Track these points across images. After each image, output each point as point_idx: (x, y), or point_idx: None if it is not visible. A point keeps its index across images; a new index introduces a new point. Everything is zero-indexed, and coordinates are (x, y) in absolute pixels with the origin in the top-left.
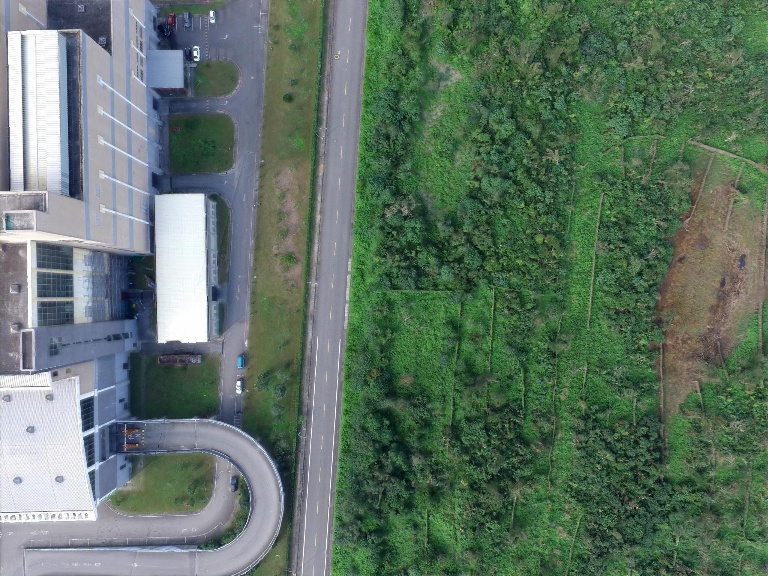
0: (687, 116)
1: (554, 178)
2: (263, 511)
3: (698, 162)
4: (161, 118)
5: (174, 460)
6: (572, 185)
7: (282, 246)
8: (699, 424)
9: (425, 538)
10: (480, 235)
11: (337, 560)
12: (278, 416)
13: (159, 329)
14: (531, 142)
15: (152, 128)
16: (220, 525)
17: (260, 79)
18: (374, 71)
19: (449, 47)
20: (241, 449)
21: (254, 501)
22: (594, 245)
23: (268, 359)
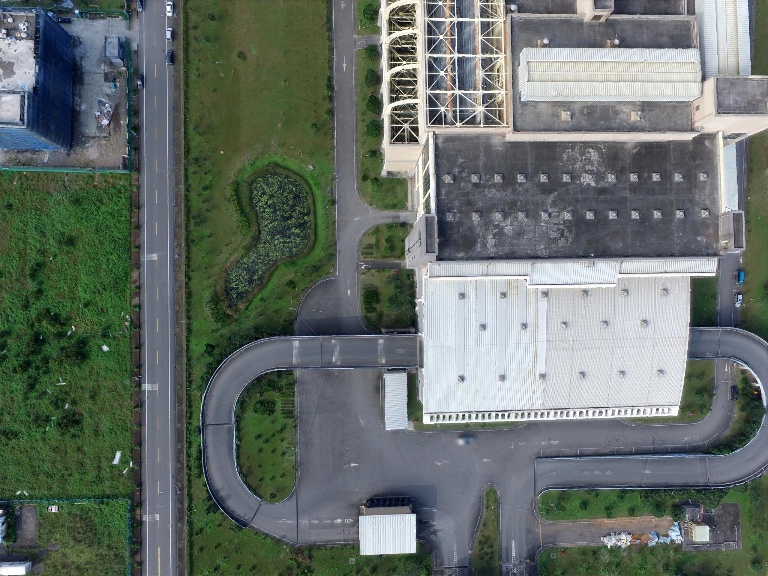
0: None
1: None
2: None
3: None
4: None
5: None
6: None
7: None
8: None
9: None
10: None
11: None
12: None
13: None
14: None
15: None
16: (720, 433)
17: (750, 13)
18: None
19: None
20: (758, 356)
21: (766, 407)
22: None
23: (764, 275)
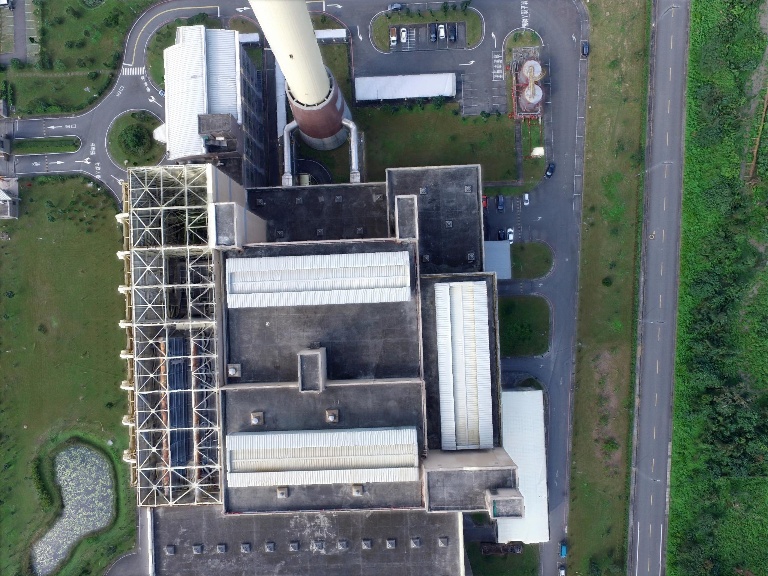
0: None
1: None
2: None
3: None
4: None
5: None
6: None
7: (602, 431)
8: None
9: None
10: None
11: None
12: None
13: (500, 529)
14: None
15: None
16: None
17: (575, 261)
18: (692, 252)
19: None
20: None
21: None
22: None
23: (590, 546)
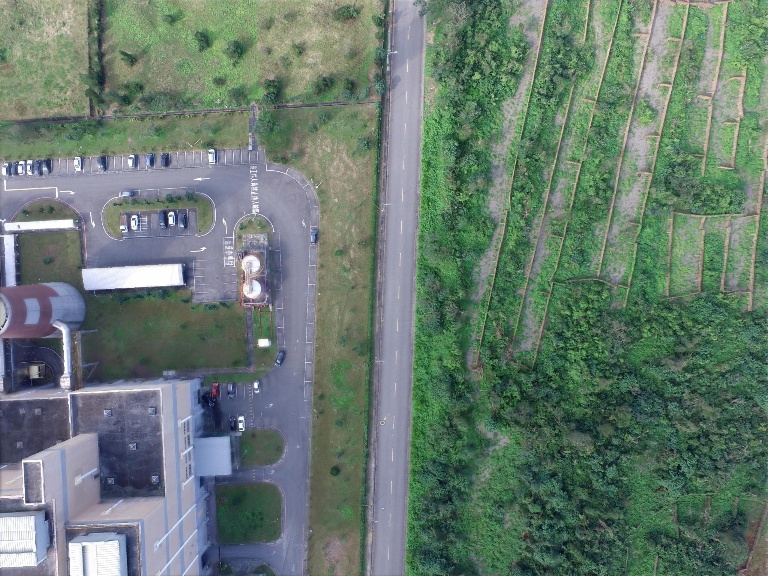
0: (741, 469)
1: (608, 552)
2: None
3: (753, 511)
4: (208, 488)
5: None
6: (626, 550)
7: None
8: None
9: None
10: None
11: None
12: None
13: None
14: (584, 516)
15: (200, 509)
16: None
17: (306, 448)
18: (421, 439)
19: (497, 418)
20: None
21: None
22: None
23: None
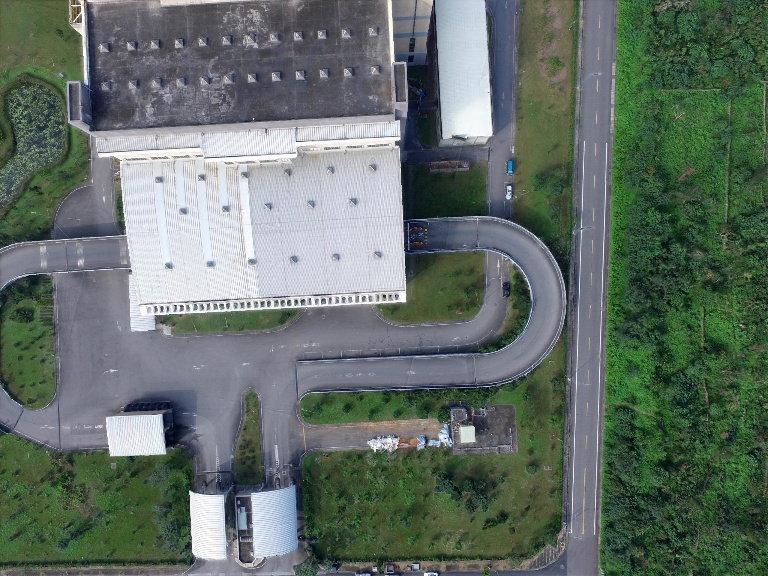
0: None
1: None
2: (544, 310)
3: None
4: None
5: (445, 268)
6: None
7: (547, 51)
8: None
9: (701, 338)
10: (754, 28)
11: (613, 363)
12: (556, 215)
13: (444, 124)
14: None
15: None
16: (492, 332)
17: None
18: None
19: None
20: (522, 247)
21: (534, 301)
22: None
23: (536, 164)
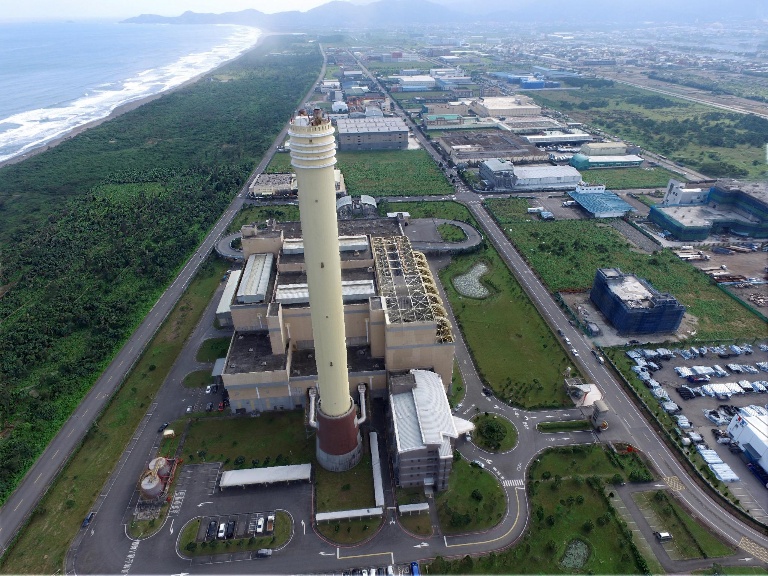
0: None
1: (0, 340)
2: None
3: None
4: None
5: None
6: None
7: None
8: (4, 276)
9: None
10: None
11: None
12: (209, 261)
13: None
14: None
15: None
16: None
17: None
18: None
19: None
20: None
21: None
22: (1, 324)
23: None
